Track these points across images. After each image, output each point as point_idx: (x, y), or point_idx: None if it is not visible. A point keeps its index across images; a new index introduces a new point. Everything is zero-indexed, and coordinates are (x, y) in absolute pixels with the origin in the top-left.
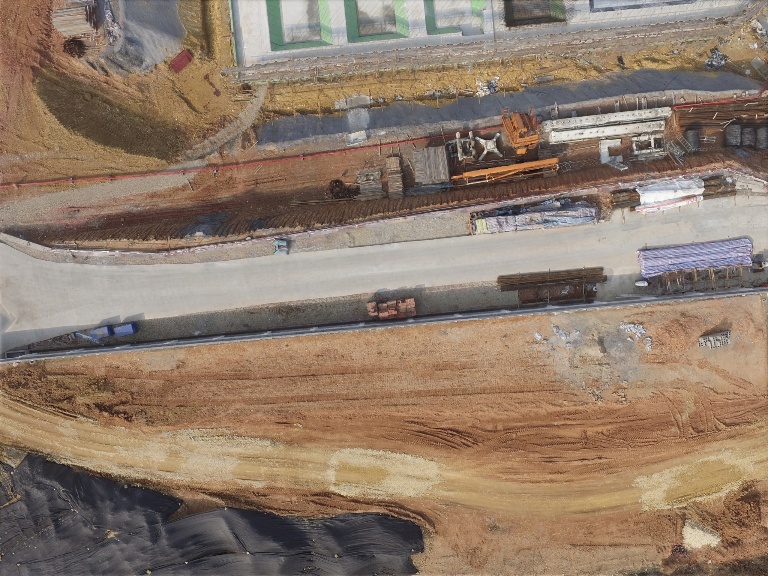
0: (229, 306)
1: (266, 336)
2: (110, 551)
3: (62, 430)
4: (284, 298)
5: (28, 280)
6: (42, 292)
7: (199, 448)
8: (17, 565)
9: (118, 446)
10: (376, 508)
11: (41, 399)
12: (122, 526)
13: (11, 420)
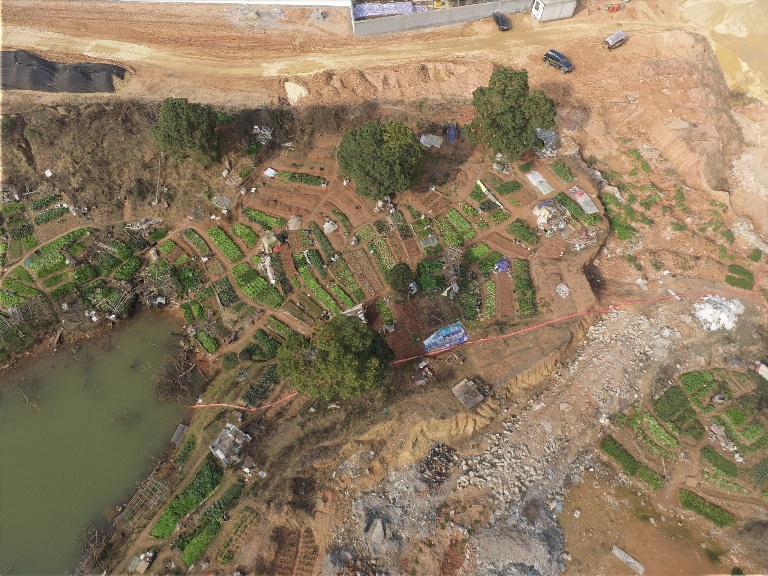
0: None
1: None
2: None
3: None
4: None
5: None
6: None
7: (22, 33)
8: None
9: None
10: (105, 61)
11: None
12: None
13: None
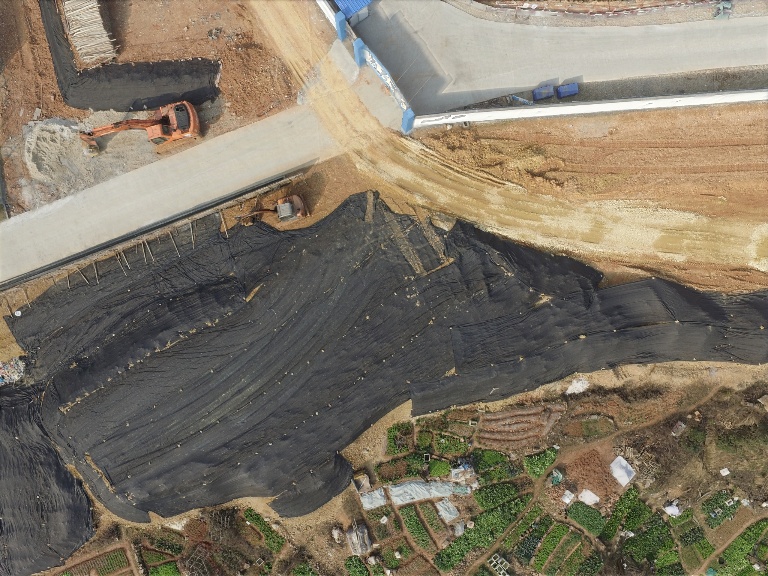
0: (667, 71)
1: (724, 91)
2: (543, 316)
3: (489, 197)
4: (722, 64)
5: (468, 40)
6: (481, 52)
7: (623, 219)
8: (449, 328)
9: (544, 215)
10: None
11: (474, 163)
12: (556, 290)
13: (440, 186)
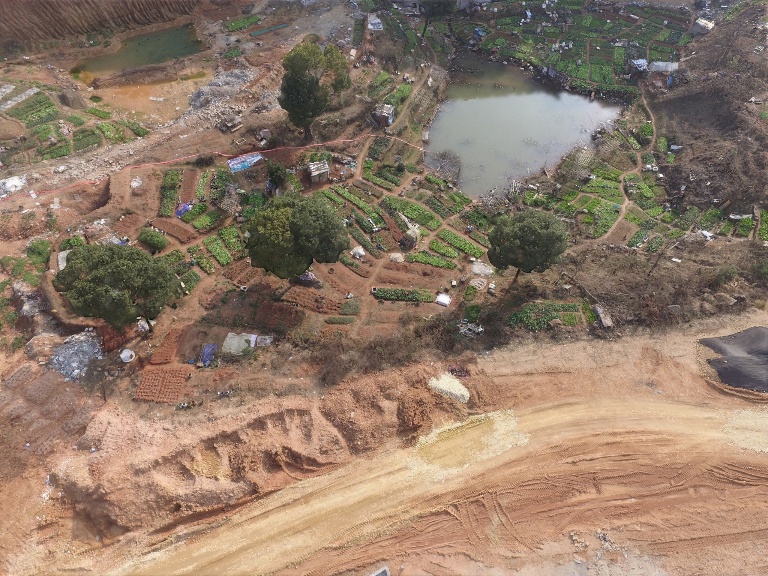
0: None
1: None
2: None
3: None
4: None
5: None
6: None
7: None
8: None
9: None
10: None
11: None
12: None
13: None
